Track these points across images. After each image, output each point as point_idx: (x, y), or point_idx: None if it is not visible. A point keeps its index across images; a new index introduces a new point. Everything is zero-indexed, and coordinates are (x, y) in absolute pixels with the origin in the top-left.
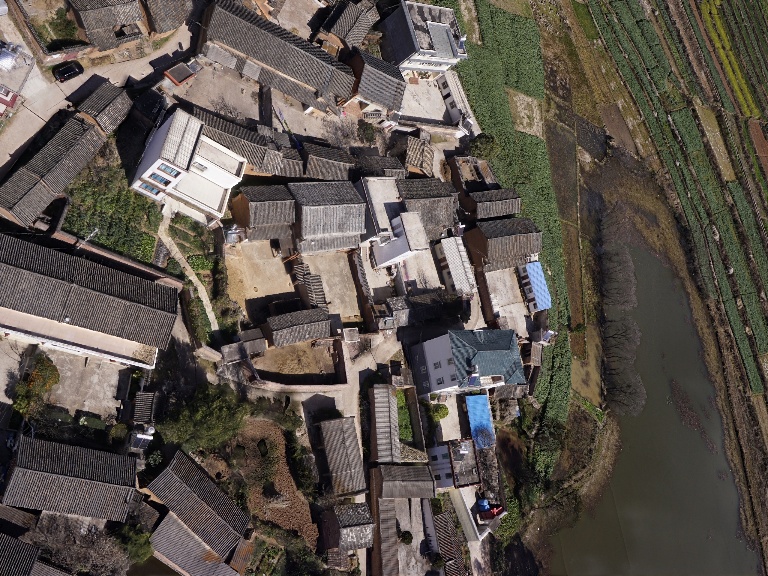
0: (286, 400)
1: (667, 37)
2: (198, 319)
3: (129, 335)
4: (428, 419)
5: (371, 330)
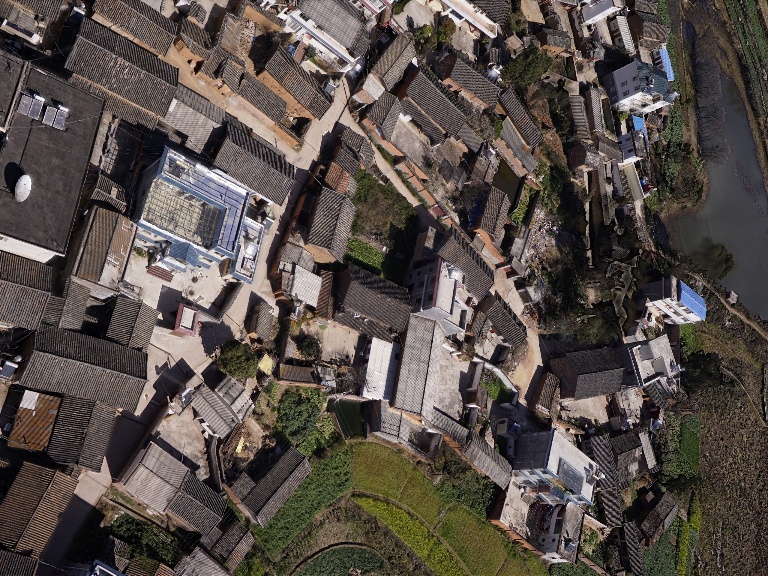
0: (568, 63)
1: None
2: None
3: (489, 12)
4: (615, 120)
5: None
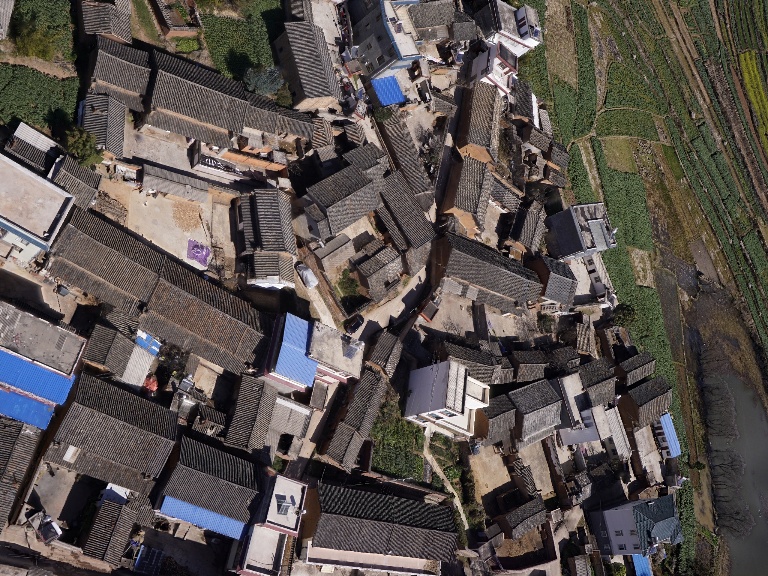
0: None
1: (735, 165)
2: (461, 527)
3: (427, 556)
4: None
5: (564, 504)
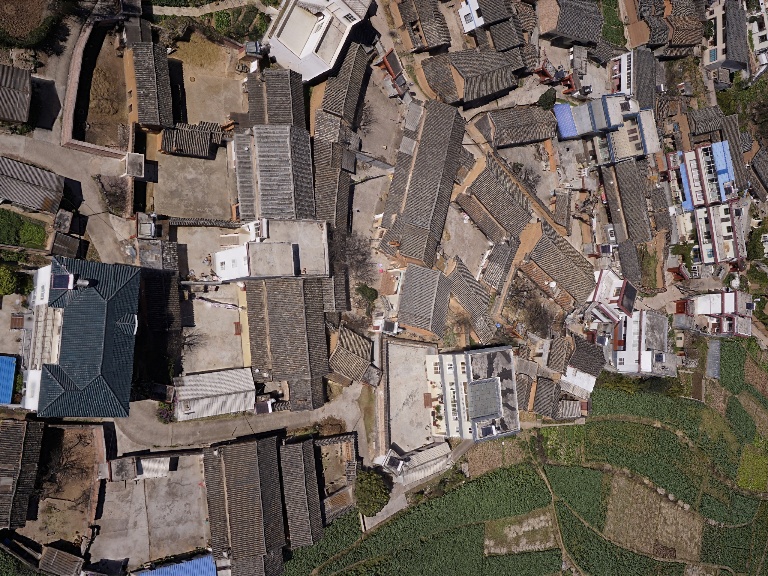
0: None
1: None
2: None
3: None
4: None
5: None
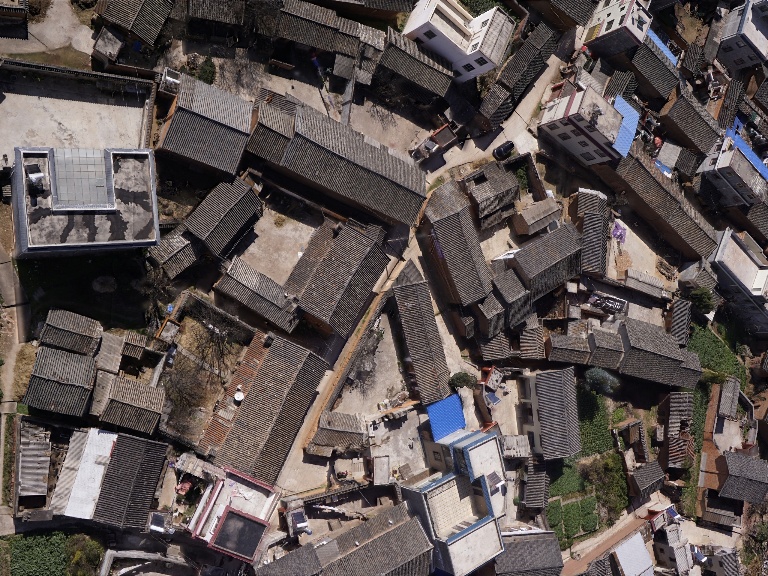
0: None
1: None
2: None
3: None
4: None
5: None
